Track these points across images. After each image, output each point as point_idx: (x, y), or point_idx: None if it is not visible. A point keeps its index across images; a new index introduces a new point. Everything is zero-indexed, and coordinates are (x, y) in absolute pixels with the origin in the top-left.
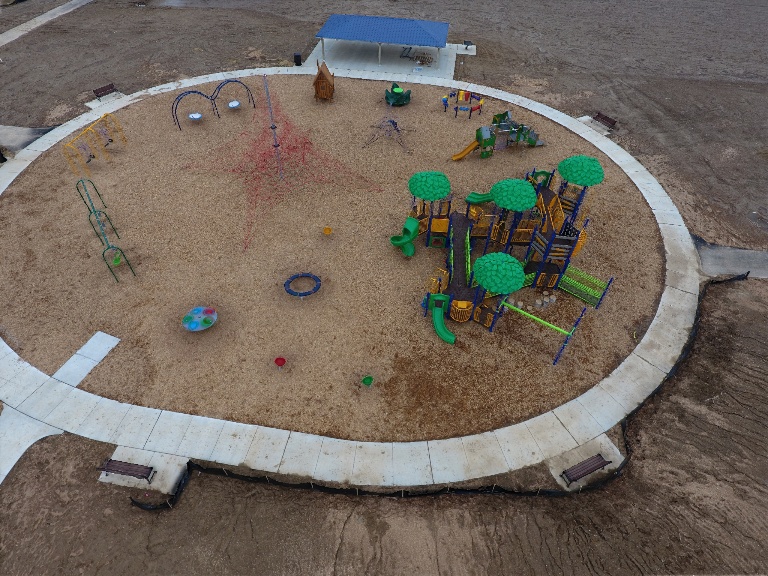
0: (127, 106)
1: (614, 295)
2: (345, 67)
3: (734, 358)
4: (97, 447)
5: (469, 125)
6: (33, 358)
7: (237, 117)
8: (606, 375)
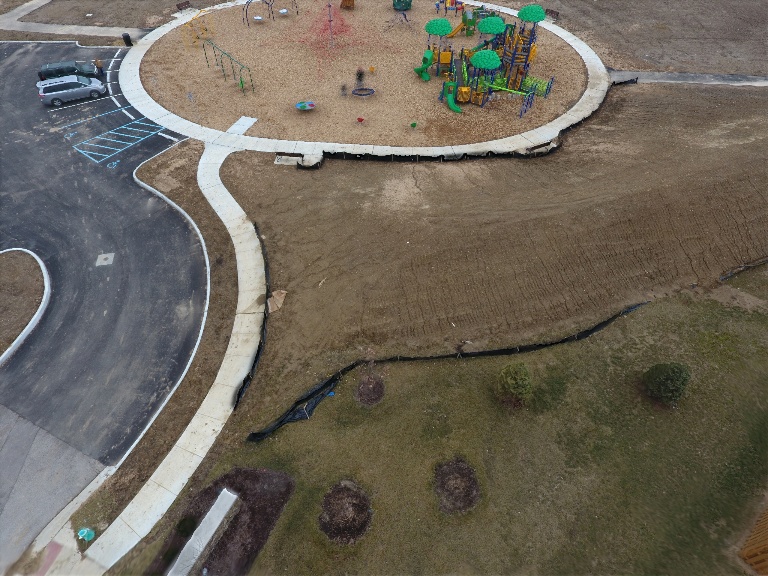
0: (203, 16)
1: (556, 93)
2: None
3: (622, 109)
4: (267, 154)
5: (456, 20)
6: (210, 126)
7: (287, 20)
8: (550, 121)
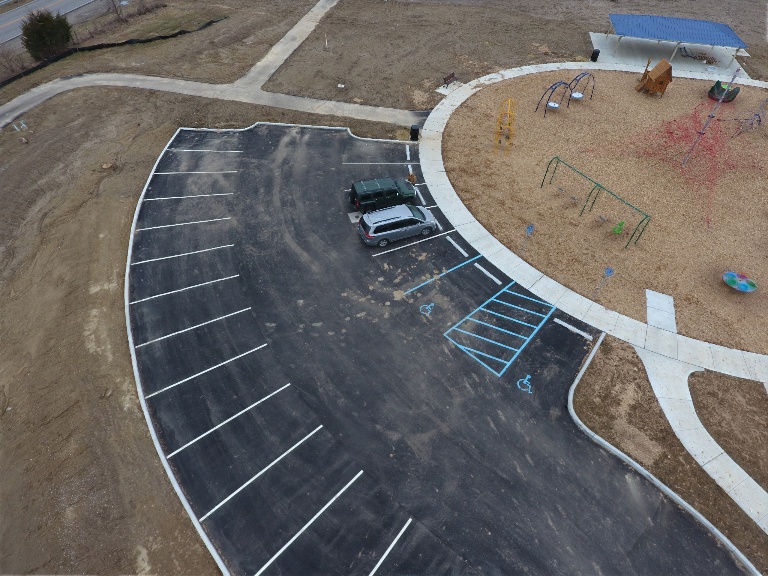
0: (475, 94)
1: None
2: (639, 64)
3: None
4: (745, 383)
5: None
6: (617, 308)
7: (584, 107)
8: None
